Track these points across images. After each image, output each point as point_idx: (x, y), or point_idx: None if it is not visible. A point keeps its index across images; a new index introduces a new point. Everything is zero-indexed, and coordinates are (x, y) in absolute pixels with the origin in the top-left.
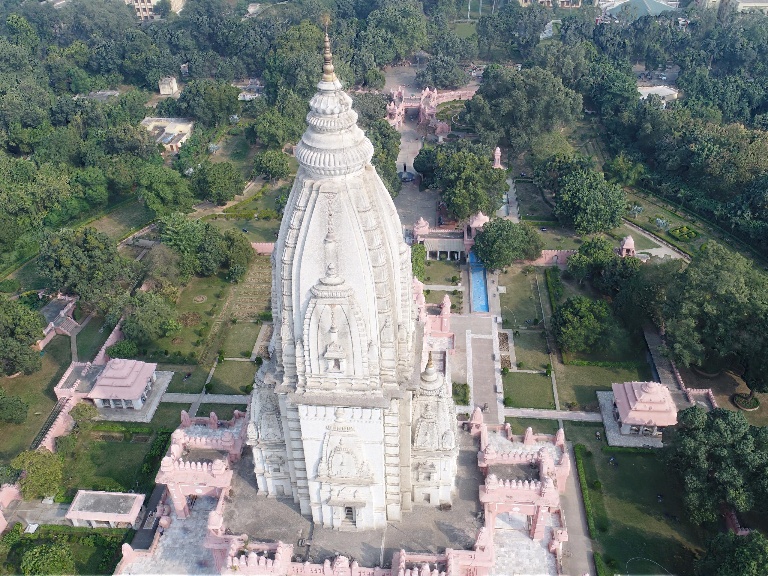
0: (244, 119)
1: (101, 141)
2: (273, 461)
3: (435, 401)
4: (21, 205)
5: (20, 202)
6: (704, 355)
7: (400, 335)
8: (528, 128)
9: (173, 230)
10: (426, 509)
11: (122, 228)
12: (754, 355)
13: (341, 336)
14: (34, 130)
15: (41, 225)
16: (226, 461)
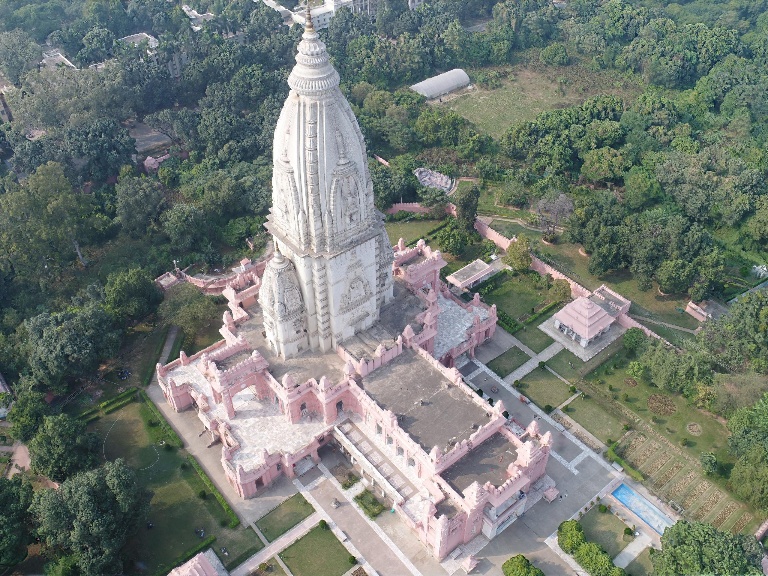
0: None
1: None
2: None
3: None
4: None
5: None
6: None
7: None
8: None
9: None
10: None
11: None
12: None
13: None
14: None
15: None
16: None
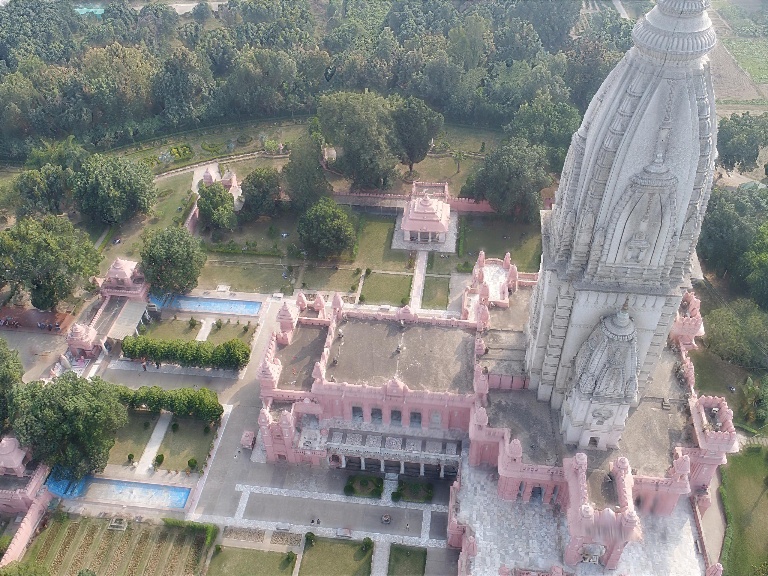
0: None
1: None
2: None
3: None
4: None
5: None
6: None
7: None
8: None
9: None
10: None
11: None
12: None
13: None
14: None
15: None
16: None
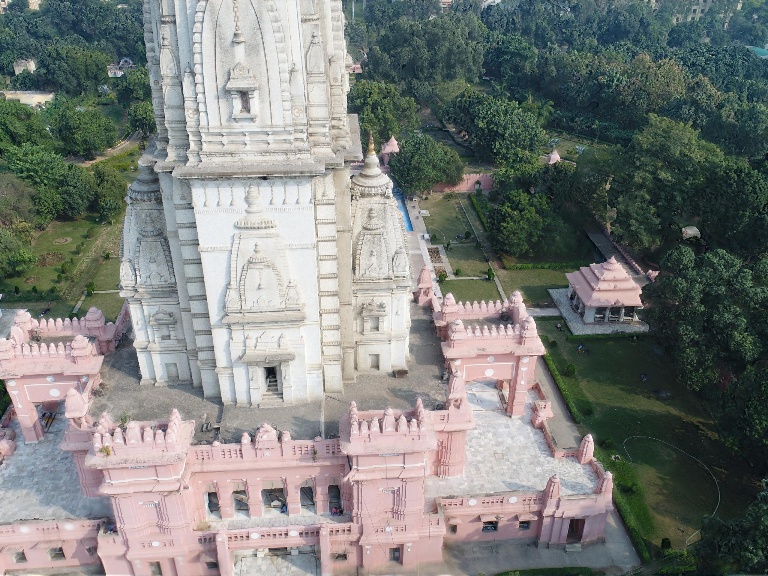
0: (115, 93)
1: None
2: (160, 320)
3: (381, 203)
4: None
5: None
6: (660, 237)
7: (332, 72)
8: (430, 78)
9: (25, 160)
10: (375, 378)
11: None
12: (717, 221)
13: (249, 52)
14: None
15: None
16: (93, 348)
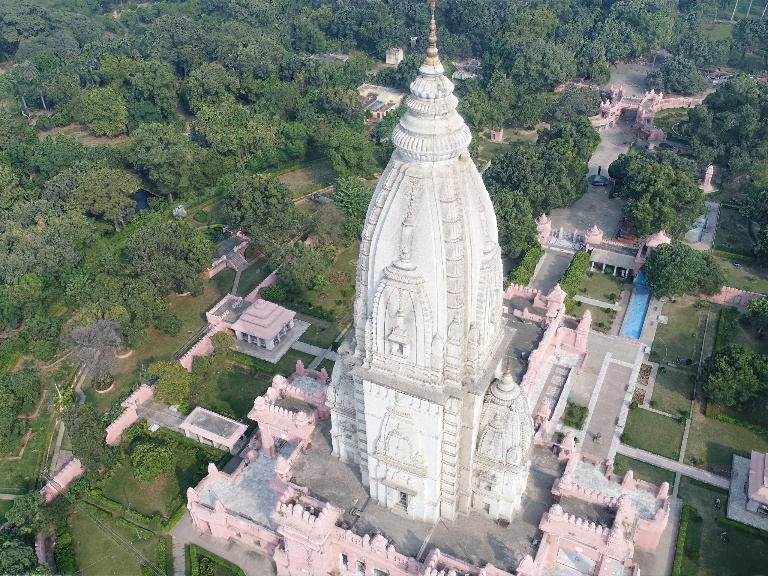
0: None
1: (313, 100)
2: (346, 427)
3: (505, 412)
4: (230, 147)
5: (230, 144)
6: None
7: (471, 335)
8: (753, 149)
9: (346, 192)
10: (483, 518)
11: (311, 183)
12: None
13: (407, 322)
14: (263, 82)
15: (243, 168)
16: (312, 415)
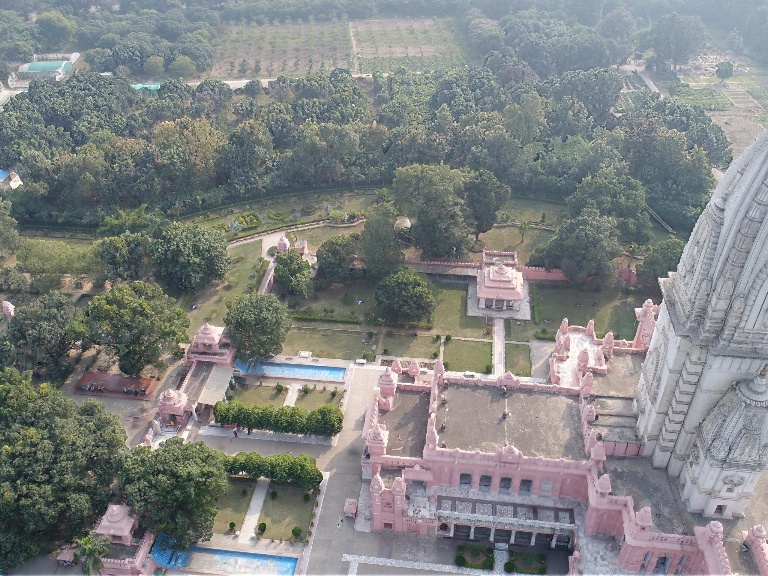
0: None
1: None
2: None
3: None
4: None
5: None
6: None
7: None
8: None
9: None
10: None
11: None
12: None
13: None
14: None
15: None
16: None
